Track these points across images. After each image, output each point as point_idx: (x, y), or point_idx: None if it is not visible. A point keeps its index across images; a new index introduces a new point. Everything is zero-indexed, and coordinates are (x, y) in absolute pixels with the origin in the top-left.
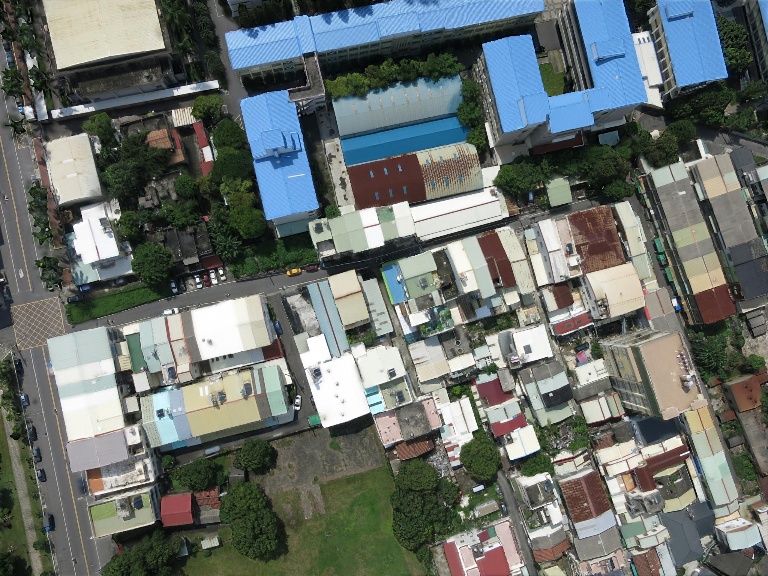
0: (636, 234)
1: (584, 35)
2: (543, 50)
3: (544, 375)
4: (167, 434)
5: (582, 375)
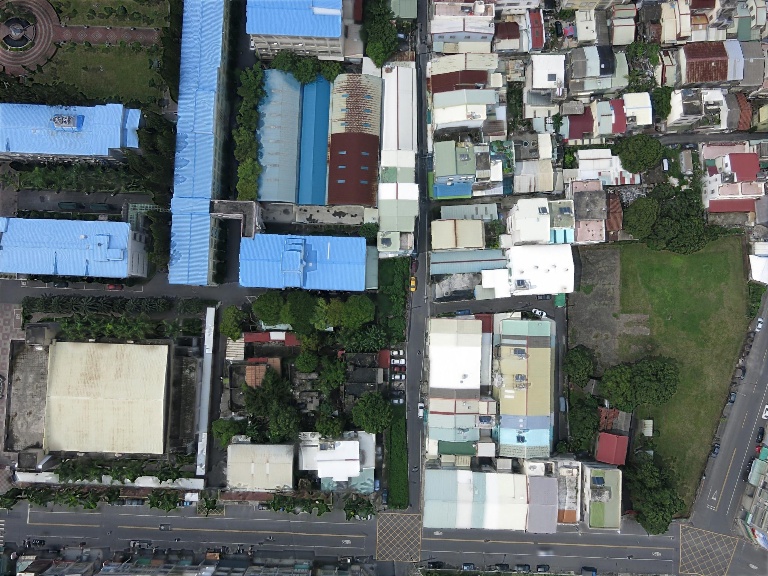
0: None
1: None
2: None
3: (582, 67)
4: (541, 439)
5: (586, 35)
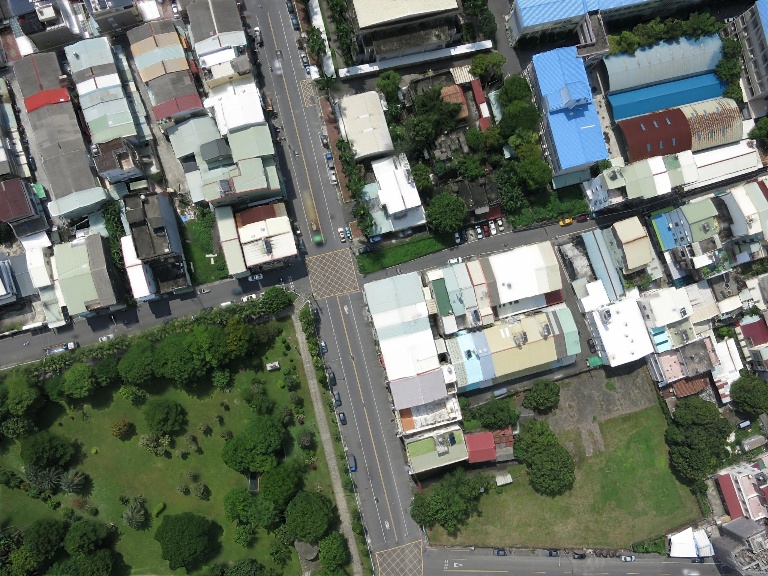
0: None
1: None
2: None
3: None
4: (473, 374)
5: None
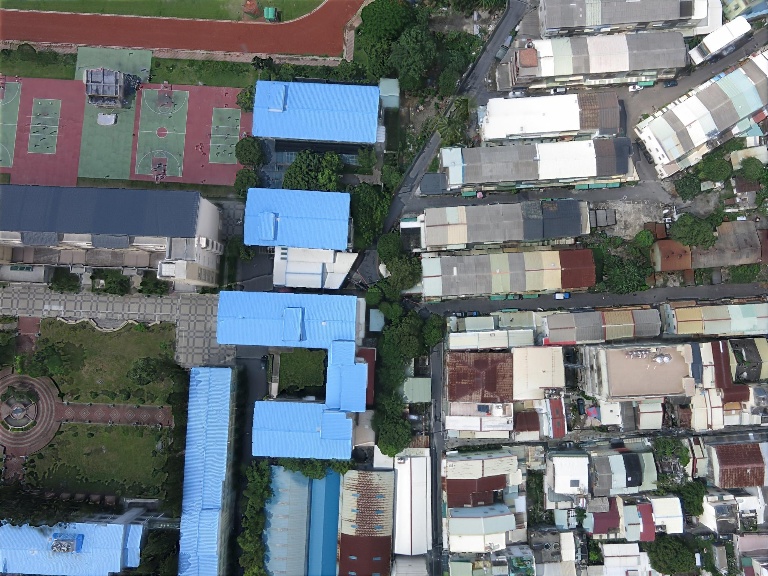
0: (486, 337)
1: (271, 344)
2: (266, 358)
3: (608, 480)
4: None
5: (611, 420)
